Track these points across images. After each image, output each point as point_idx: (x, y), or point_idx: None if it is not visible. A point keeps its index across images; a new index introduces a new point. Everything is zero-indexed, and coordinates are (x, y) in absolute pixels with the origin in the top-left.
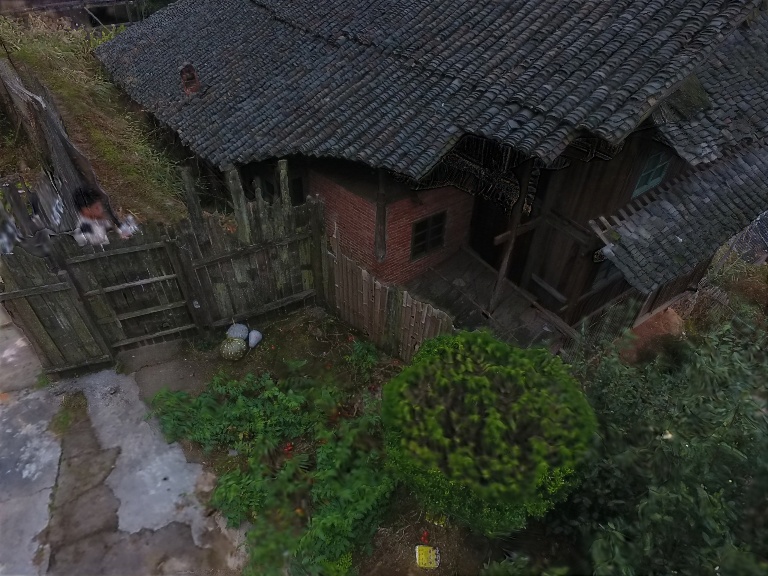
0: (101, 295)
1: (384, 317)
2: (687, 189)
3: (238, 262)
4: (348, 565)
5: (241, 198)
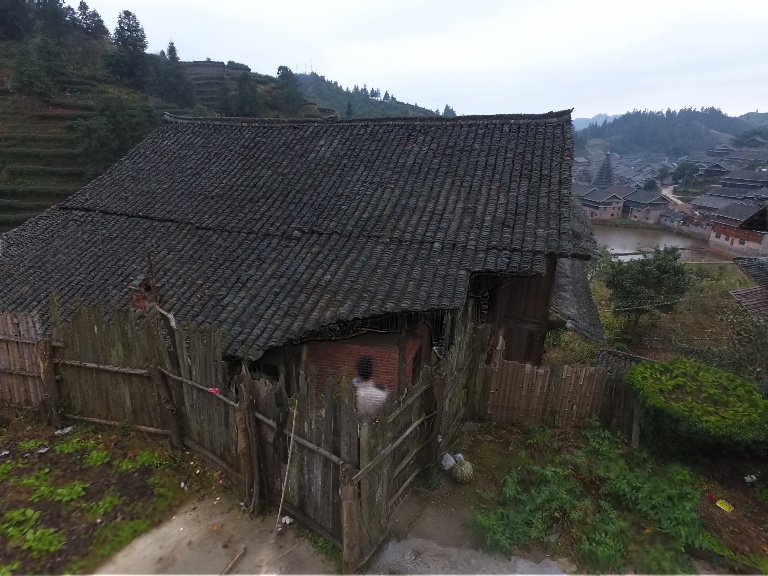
0: None
1: (542, 397)
2: (561, 283)
3: (449, 391)
4: (709, 535)
5: None
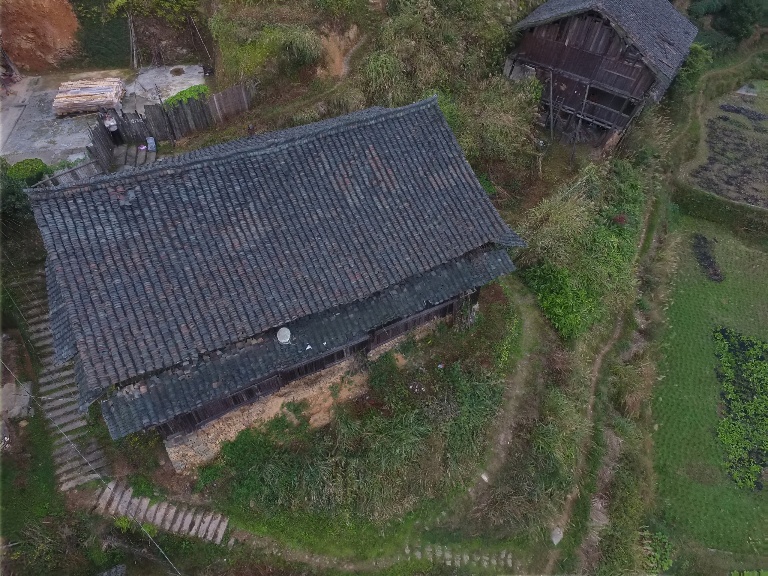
0: (105, 133)
1: None
2: None
3: None
4: None
5: (91, 135)
